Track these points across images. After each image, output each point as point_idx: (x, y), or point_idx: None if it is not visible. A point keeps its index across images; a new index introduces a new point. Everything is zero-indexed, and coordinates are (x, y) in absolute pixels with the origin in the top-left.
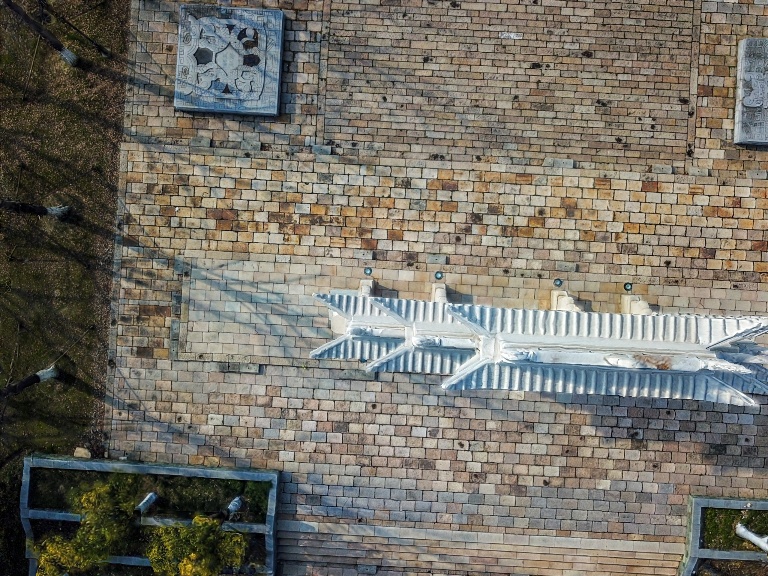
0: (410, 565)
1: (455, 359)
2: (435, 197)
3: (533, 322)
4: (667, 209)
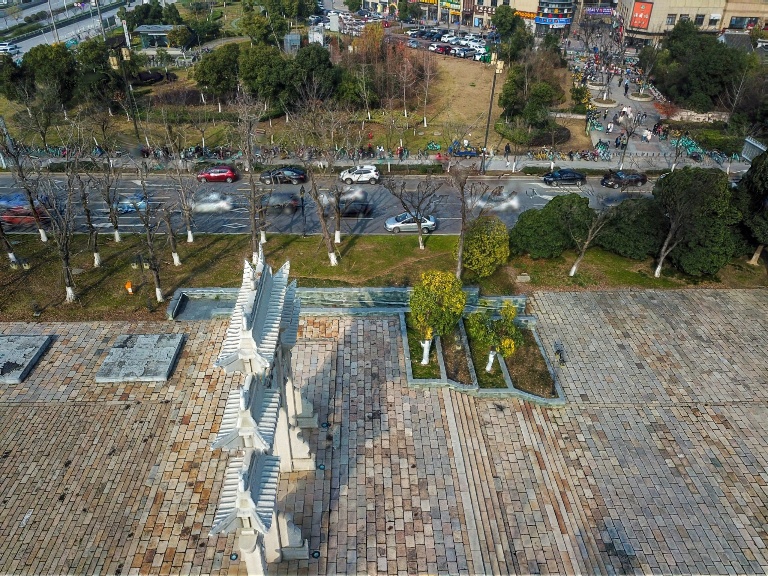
0: (513, 570)
1: (266, 405)
2: (158, 568)
3: (234, 337)
4: (205, 410)
